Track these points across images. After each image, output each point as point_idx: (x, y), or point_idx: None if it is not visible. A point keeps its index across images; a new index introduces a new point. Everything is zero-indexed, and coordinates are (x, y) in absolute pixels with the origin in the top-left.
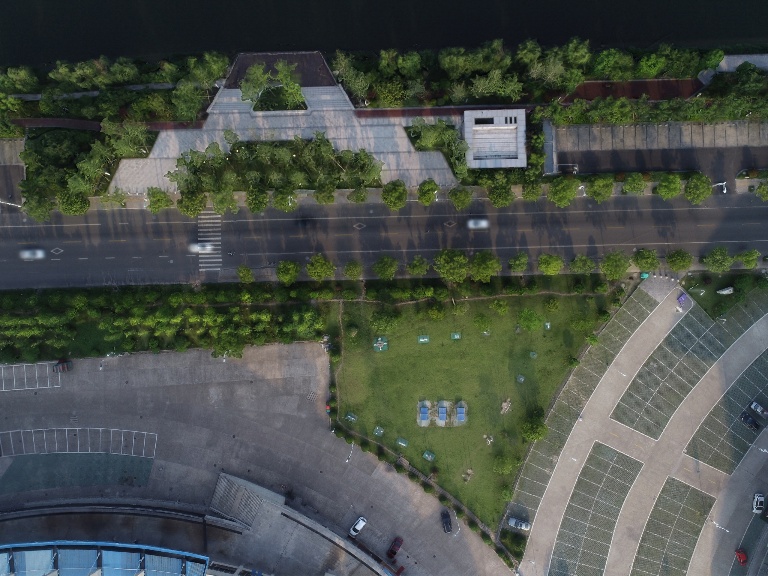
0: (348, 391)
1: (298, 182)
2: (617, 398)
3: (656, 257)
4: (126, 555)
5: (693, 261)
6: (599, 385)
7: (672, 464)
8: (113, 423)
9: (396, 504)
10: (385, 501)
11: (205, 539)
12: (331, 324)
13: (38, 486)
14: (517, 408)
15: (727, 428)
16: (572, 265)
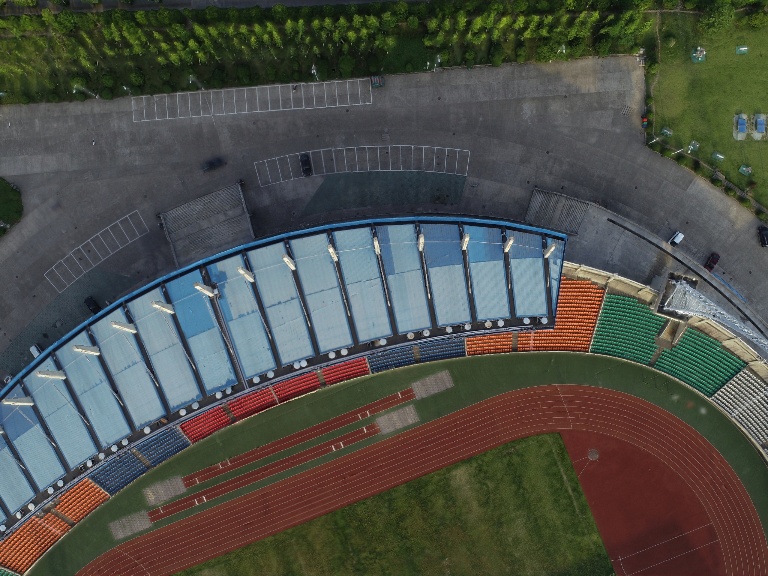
0: (664, 104)
1: None
2: None
3: None
4: (487, 230)
5: None
6: None
7: None
8: (425, 140)
9: (712, 220)
10: (700, 217)
11: None
12: (647, 35)
13: (349, 205)
14: None
15: None
16: None
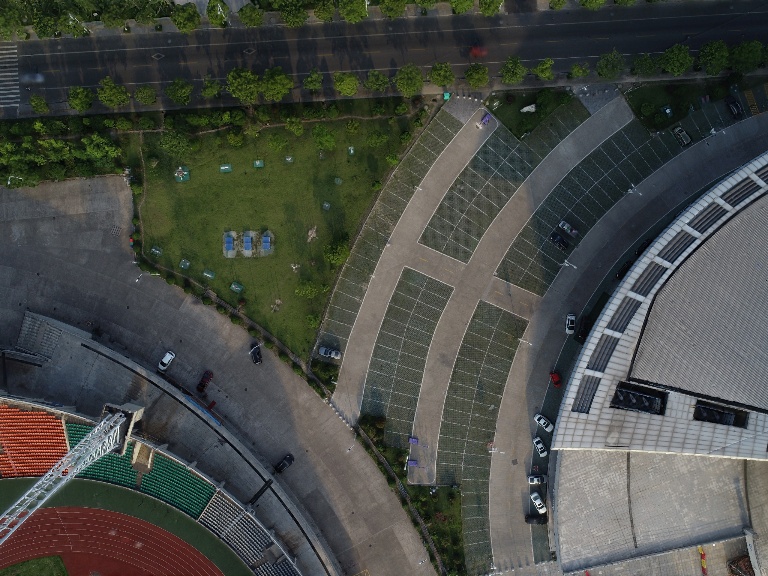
0: (152, 224)
1: (85, 5)
2: (425, 222)
3: (459, 78)
4: None
5: (496, 81)
6: (406, 210)
7: (483, 287)
8: None
9: (205, 338)
10: (194, 335)
11: (5, 373)
12: (132, 156)
13: None
14: (324, 235)
15: (537, 249)
16: (366, 81)
